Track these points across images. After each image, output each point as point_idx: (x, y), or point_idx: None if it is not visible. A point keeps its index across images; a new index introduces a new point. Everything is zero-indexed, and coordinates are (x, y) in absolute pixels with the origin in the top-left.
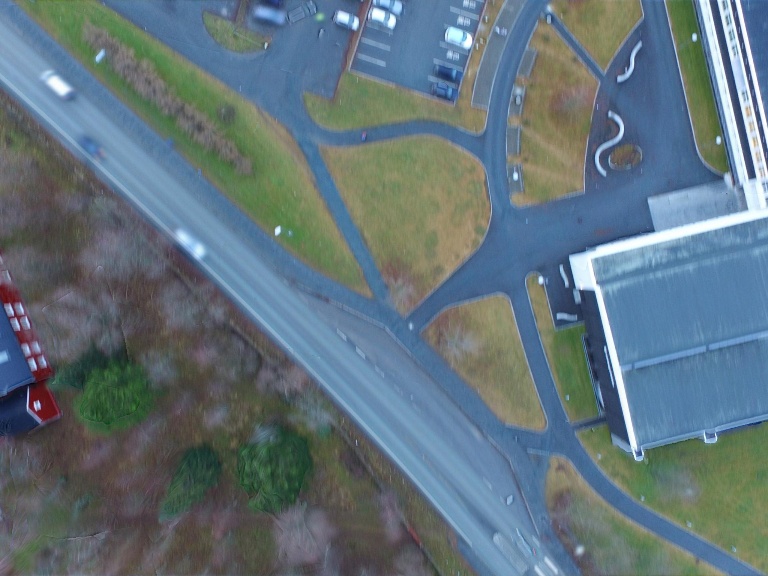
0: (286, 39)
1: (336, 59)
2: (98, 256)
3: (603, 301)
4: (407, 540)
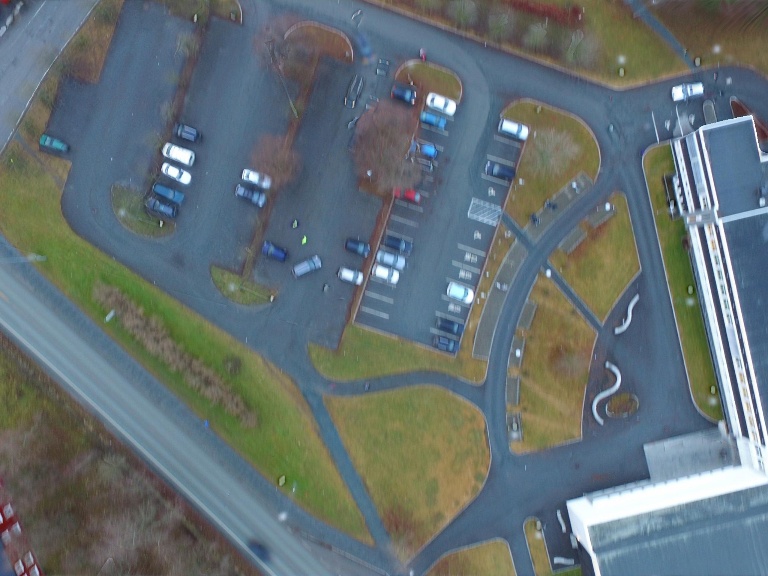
0: (292, 292)
1: (340, 311)
2: (106, 504)
3: (599, 570)
4: None
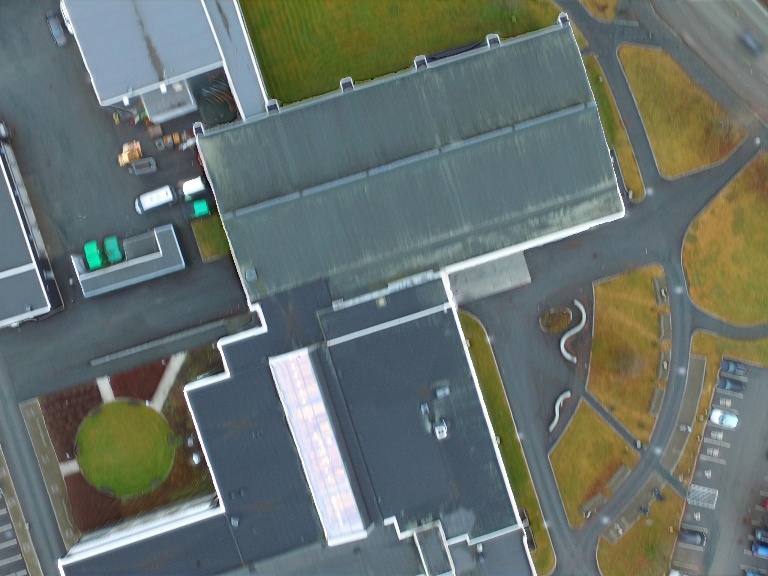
0: None
1: None
2: None
3: None
4: None
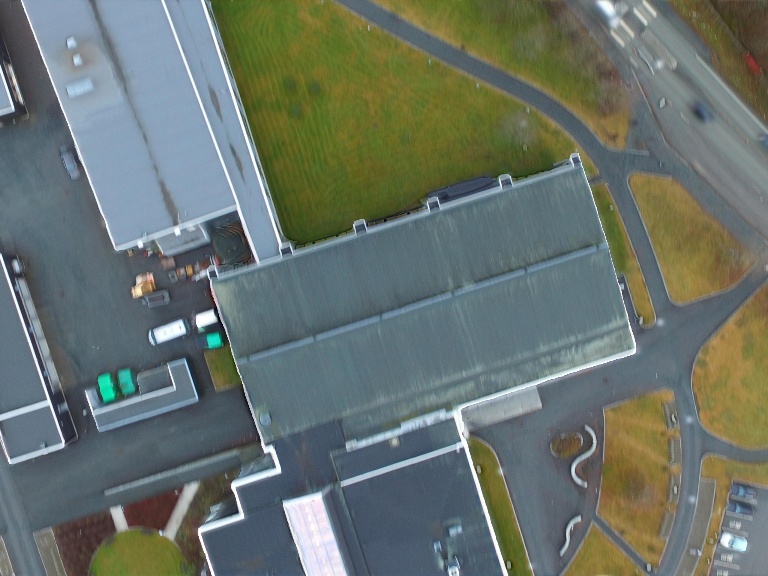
0: None
1: None
2: None
3: None
4: (762, 59)
